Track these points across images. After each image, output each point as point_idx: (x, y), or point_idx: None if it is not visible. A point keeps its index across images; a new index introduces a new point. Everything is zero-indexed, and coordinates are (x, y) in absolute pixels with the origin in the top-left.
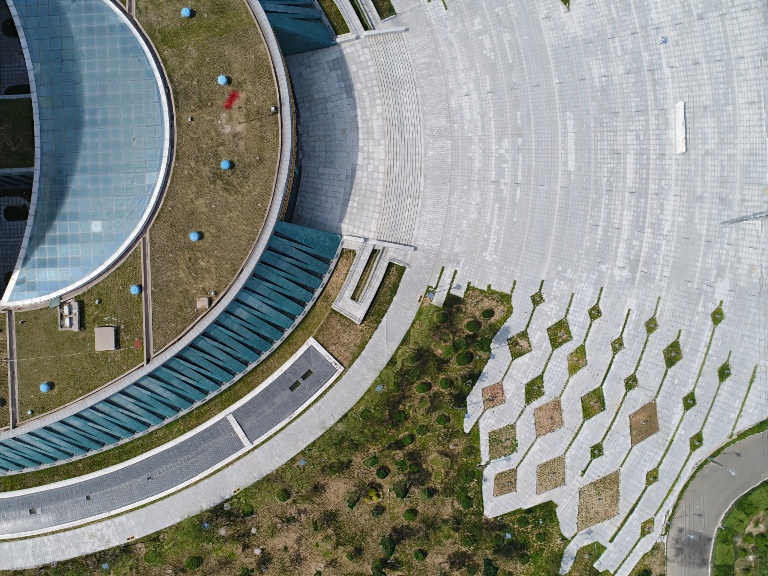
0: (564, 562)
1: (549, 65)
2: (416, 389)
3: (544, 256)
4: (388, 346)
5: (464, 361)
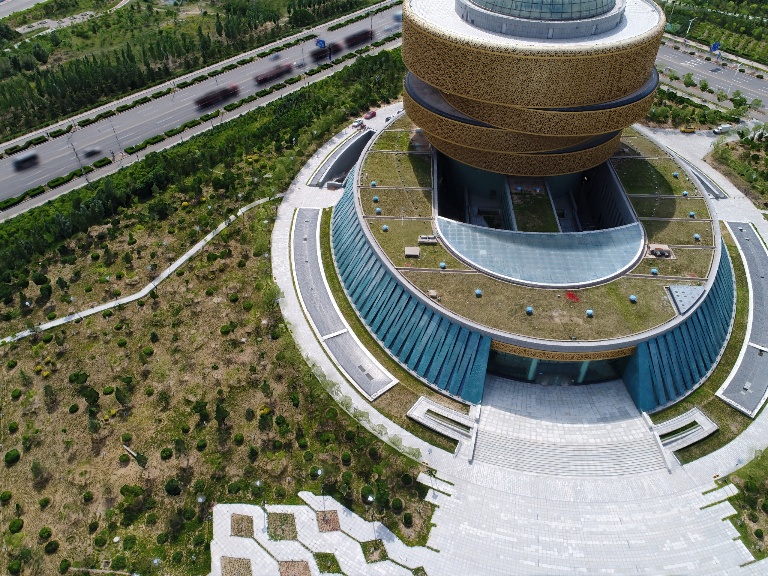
0: None
1: None
2: None
3: None
4: None
5: (366, 491)
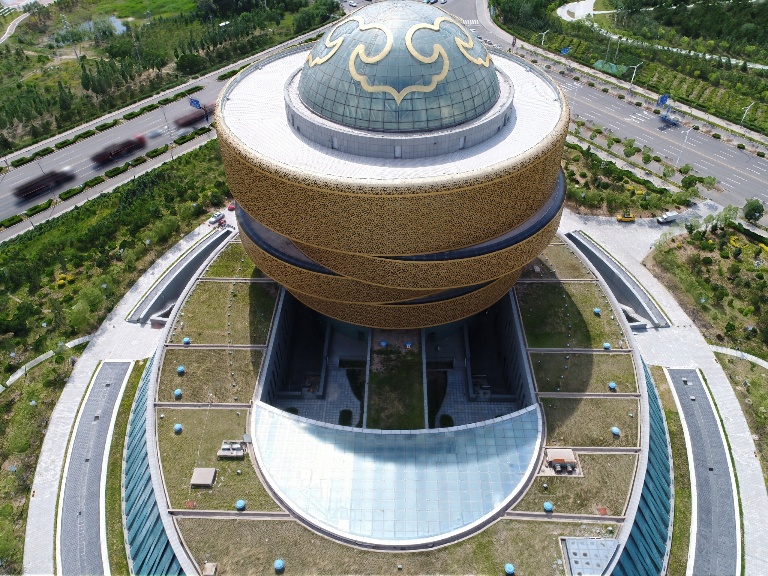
0: None
1: None
2: None
3: None
4: None
5: None
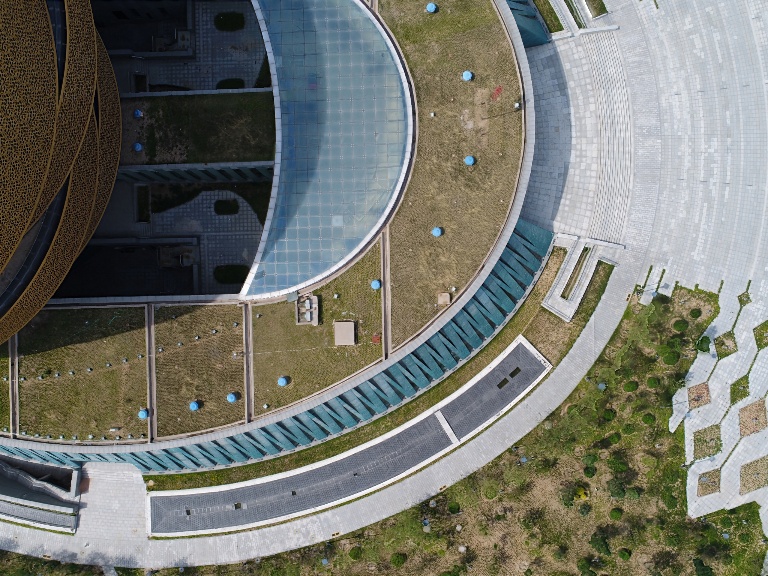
0: (766, 563)
1: (758, 65)
2: (623, 388)
3: (751, 256)
4: (596, 344)
5: (674, 360)
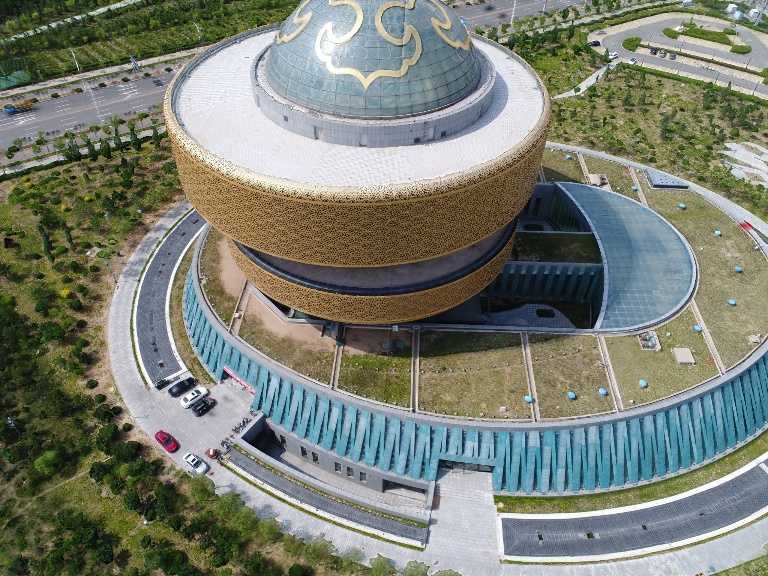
0: None
1: None
2: None
3: None
4: None
5: None
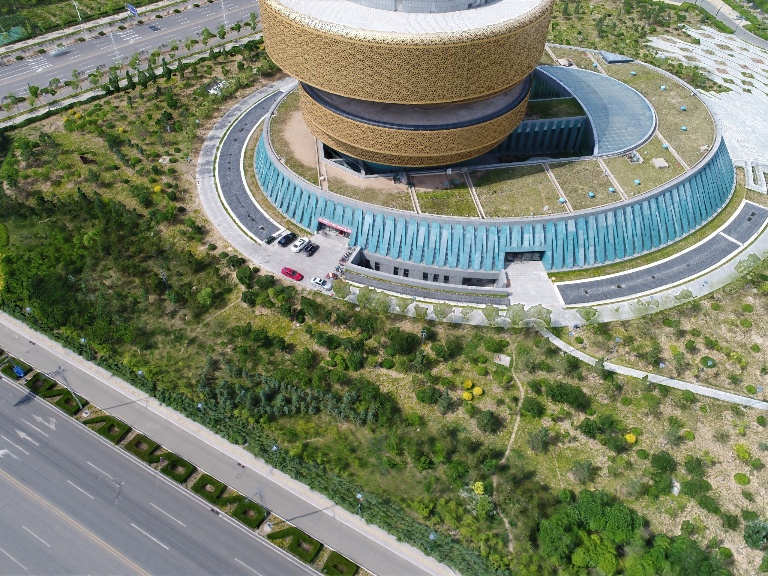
0: None
1: None
2: None
3: None
4: None
5: None
